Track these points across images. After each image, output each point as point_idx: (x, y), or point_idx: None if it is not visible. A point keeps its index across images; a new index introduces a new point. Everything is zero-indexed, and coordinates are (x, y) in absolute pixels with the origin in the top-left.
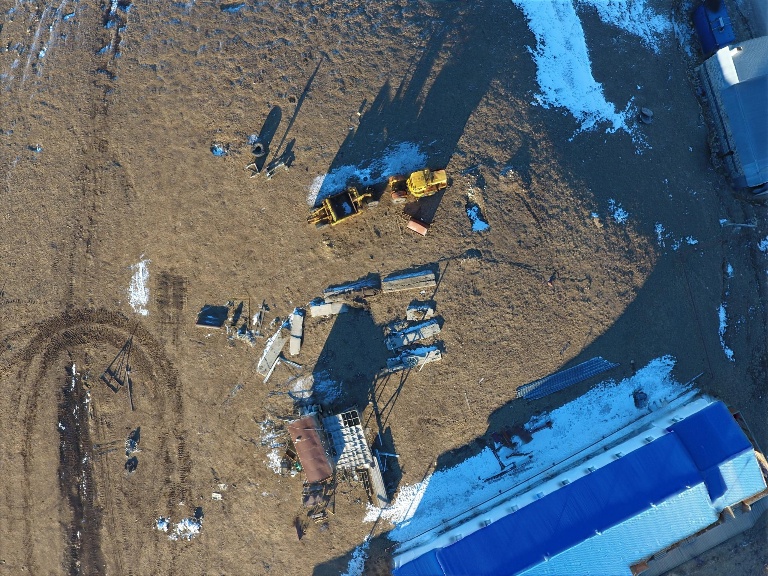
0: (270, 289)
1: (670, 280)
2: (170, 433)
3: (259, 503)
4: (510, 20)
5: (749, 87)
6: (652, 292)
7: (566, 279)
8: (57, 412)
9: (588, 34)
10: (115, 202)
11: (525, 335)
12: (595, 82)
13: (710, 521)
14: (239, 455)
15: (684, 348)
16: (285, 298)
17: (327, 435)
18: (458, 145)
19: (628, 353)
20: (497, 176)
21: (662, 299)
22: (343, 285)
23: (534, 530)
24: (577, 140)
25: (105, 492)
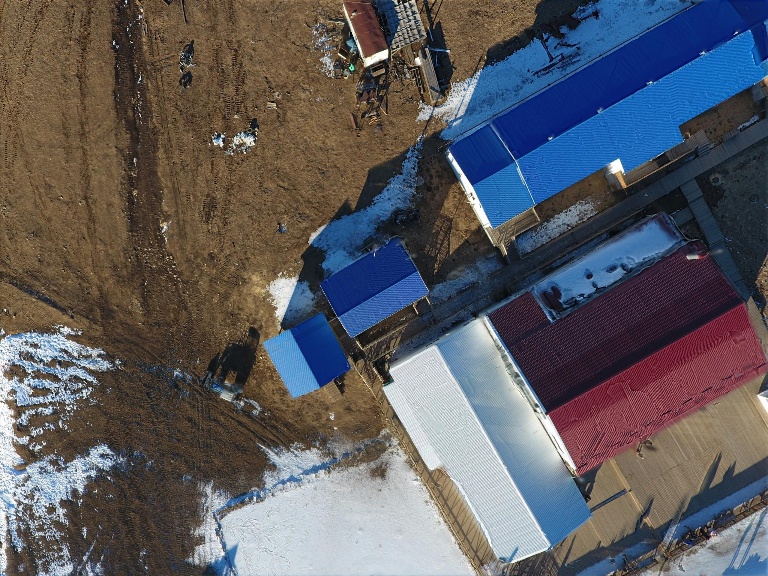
0: None
1: None
2: (223, 44)
3: (313, 109)
4: None
5: None
6: None
7: None
8: (111, 29)
9: None
10: None
11: None
12: None
13: (756, 79)
14: (292, 61)
15: None
16: None
17: (381, 16)
18: None
19: None
20: None
21: None
22: None
23: (586, 90)
24: None
25: (160, 111)
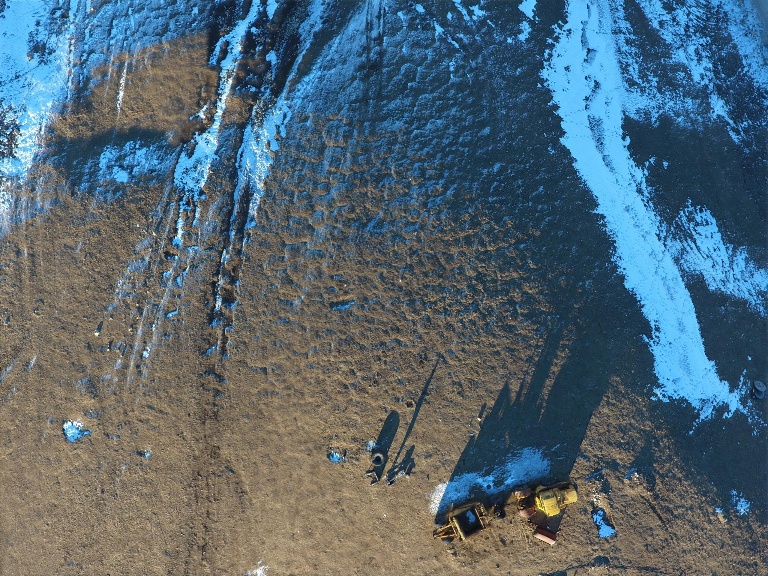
0: None
1: None
2: None
3: None
4: (625, 309)
5: None
6: None
7: None
8: None
9: (698, 307)
10: (230, 510)
11: None
12: (709, 361)
13: None
14: None
15: None
16: None
17: None
18: (581, 448)
19: None
20: (622, 479)
21: None
22: None
23: None
24: (697, 432)
25: None
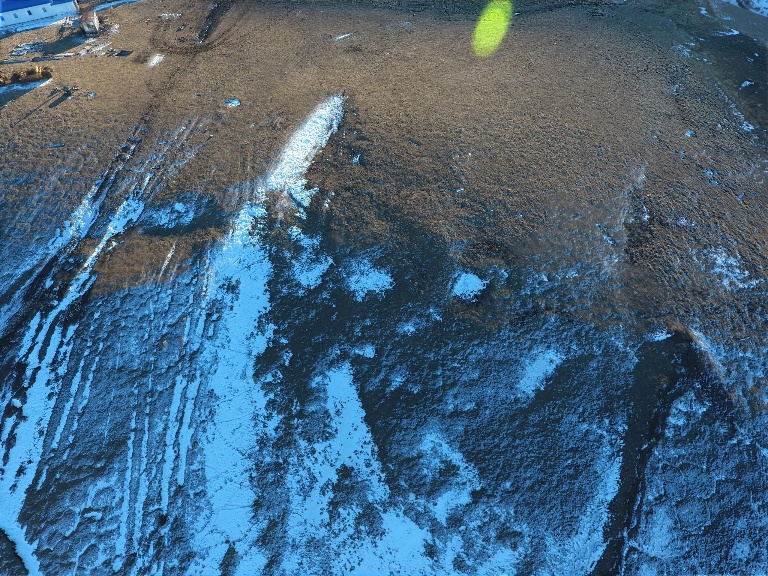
0: None
1: None
2: None
3: None
4: None
5: None
6: None
7: None
8: None
9: None
10: None
11: None
12: None
13: None
14: None
15: None
16: None
17: None
18: None
19: None
20: None
21: None
22: None
23: (7, 5)
24: None
25: None
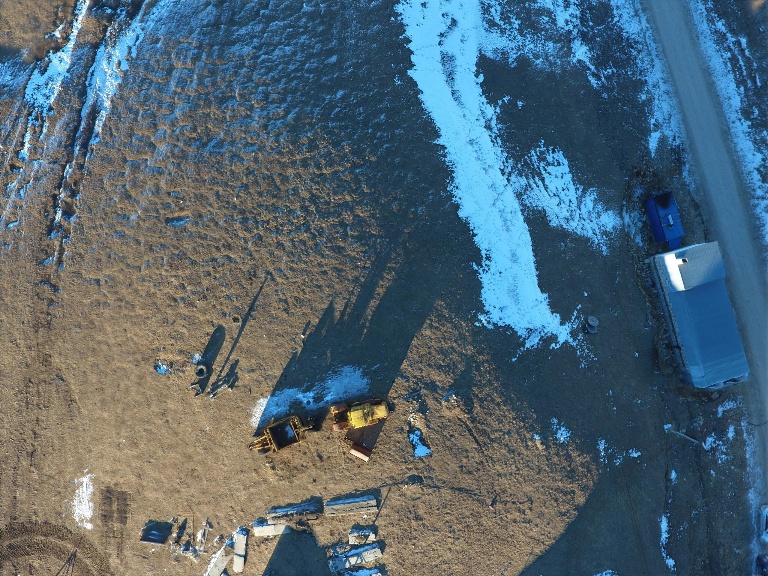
0: (214, 507)
1: (612, 496)
2: None
3: None
4: (456, 236)
5: (695, 293)
6: (594, 509)
7: (508, 502)
8: None
9: (536, 241)
10: (59, 417)
11: (466, 558)
12: (541, 293)
13: None
14: None
15: (625, 563)
16: (229, 517)
17: None
18: (401, 369)
19: (569, 571)
20: (440, 401)
21: (604, 516)
22: (286, 507)
23: None
24: (521, 359)
25: None
